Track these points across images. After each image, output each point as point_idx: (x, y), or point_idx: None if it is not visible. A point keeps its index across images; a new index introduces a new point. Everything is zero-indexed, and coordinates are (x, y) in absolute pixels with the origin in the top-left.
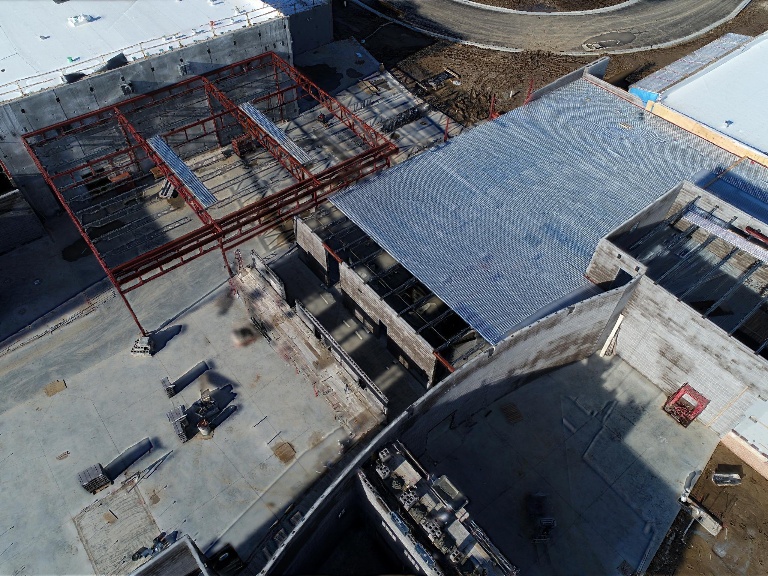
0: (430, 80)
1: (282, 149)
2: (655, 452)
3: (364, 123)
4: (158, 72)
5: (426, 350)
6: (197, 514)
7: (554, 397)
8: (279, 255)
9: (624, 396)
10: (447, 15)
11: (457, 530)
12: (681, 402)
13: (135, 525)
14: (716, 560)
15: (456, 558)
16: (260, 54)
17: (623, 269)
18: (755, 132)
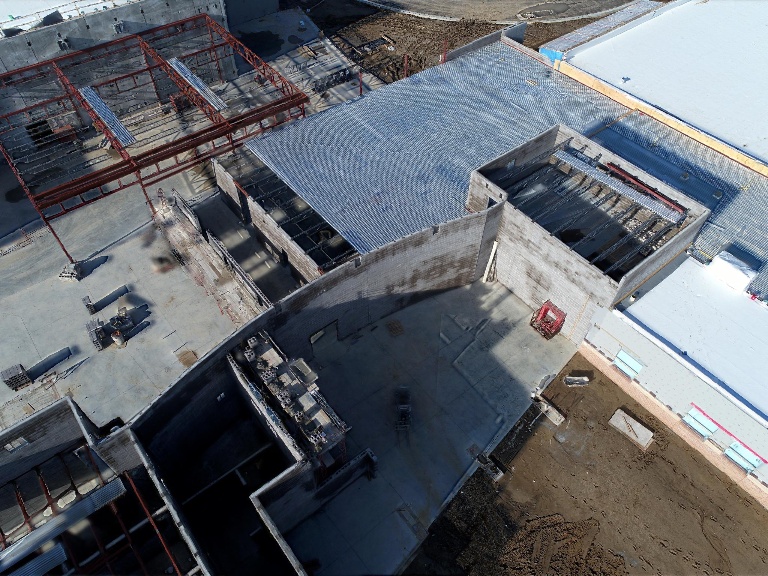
0: (366, 46)
1: (202, 98)
2: (517, 359)
3: (281, 76)
4: (93, 30)
5: (313, 268)
6: (105, 407)
7: (435, 315)
8: (204, 197)
9: (498, 315)
10: None
11: (306, 400)
12: (547, 319)
13: None
14: (555, 444)
15: (298, 418)
16: (194, 16)
17: (491, 197)
18: (649, 87)
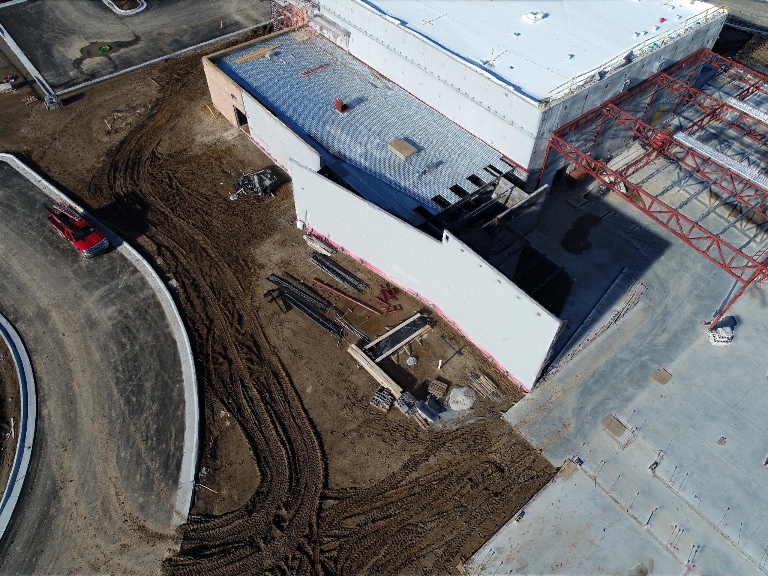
0: None
1: None
2: None
3: None
4: (644, 69)
5: None
6: None
7: None
8: None
9: None
10: (739, 8)
11: None
12: None
13: None
14: None
15: None
16: (697, 50)
17: None
18: None
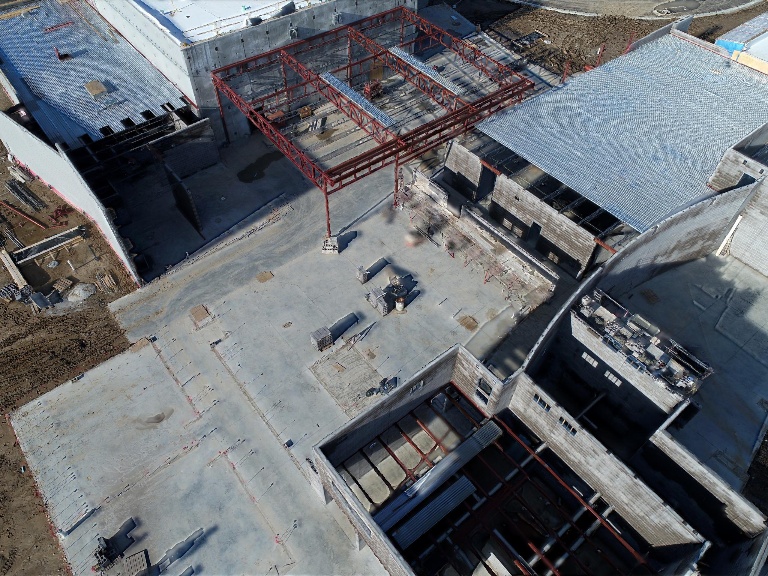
0: (523, 39)
1: (436, 83)
2: None
3: None
4: (317, 20)
5: (586, 239)
6: (409, 366)
7: (683, 285)
8: None
9: (741, 285)
10: None
11: (654, 350)
12: None
13: (361, 373)
14: None
15: (661, 364)
16: (393, 8)
17: (747, 173)
18: None
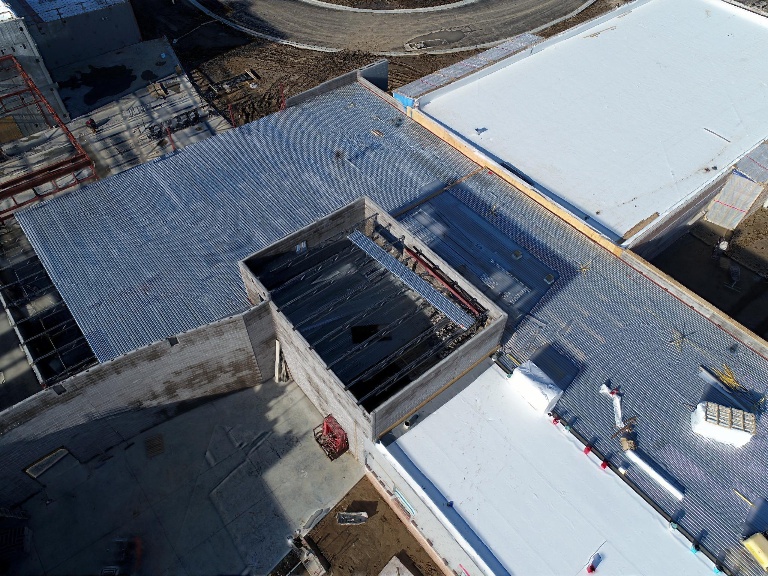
0: (225, 82)
1: None
2: (289, 488)
3: (69, 133)
4: None
5: None
6: None
7: (208, 427)
8: None
9: (283, 426)
10: (278, 13)
11: None
12: None
13: None
14: None
15: None
16: None
17: (259, 294)
18: (506, 140)
